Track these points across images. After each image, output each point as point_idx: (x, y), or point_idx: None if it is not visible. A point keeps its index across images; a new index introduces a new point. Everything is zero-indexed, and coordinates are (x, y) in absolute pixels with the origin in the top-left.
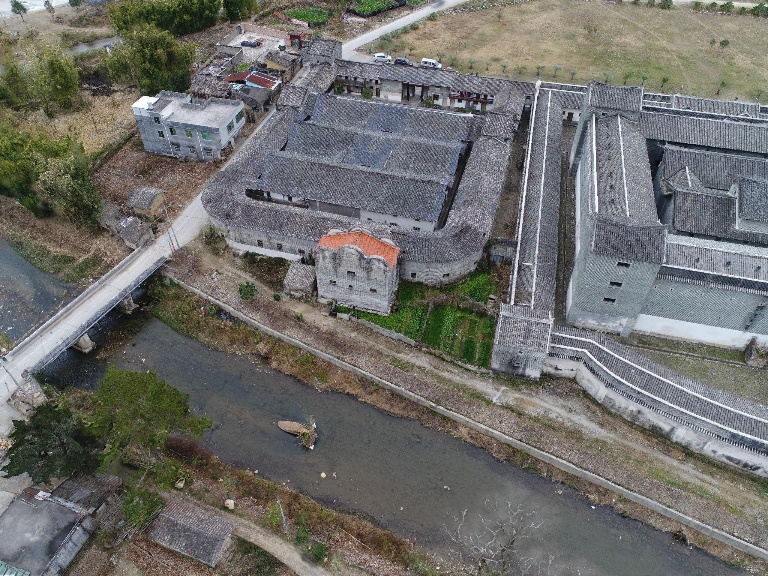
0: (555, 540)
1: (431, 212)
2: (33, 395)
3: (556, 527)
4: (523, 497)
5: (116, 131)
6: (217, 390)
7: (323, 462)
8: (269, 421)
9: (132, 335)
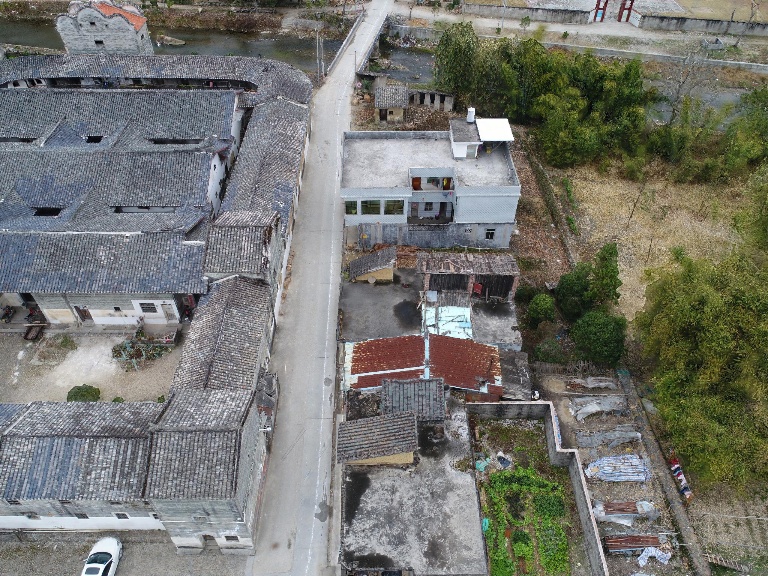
0: (4, 32)
1: (8, 88)
2: (355, 16)
3: (0, 35)
4: (16, 41)
5: (607, 239)
6: (238, 50)
7: (150, 36)
8: (193, 44)
9: (328, 64)
